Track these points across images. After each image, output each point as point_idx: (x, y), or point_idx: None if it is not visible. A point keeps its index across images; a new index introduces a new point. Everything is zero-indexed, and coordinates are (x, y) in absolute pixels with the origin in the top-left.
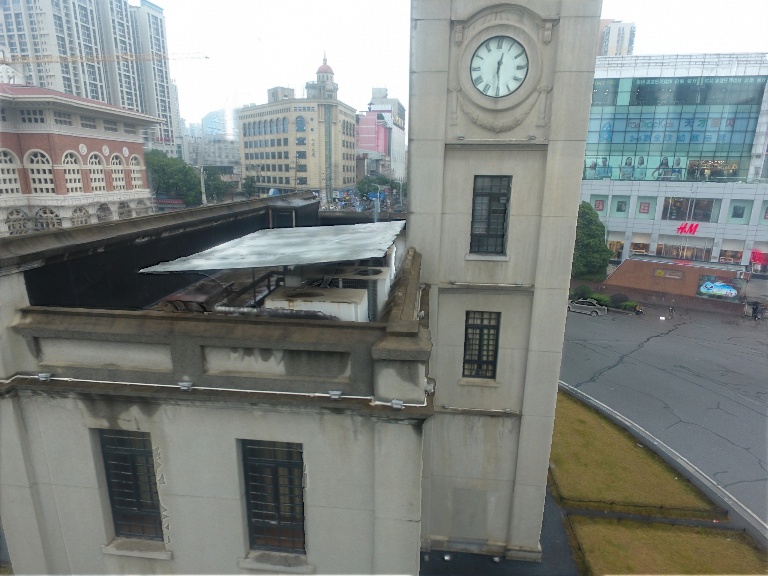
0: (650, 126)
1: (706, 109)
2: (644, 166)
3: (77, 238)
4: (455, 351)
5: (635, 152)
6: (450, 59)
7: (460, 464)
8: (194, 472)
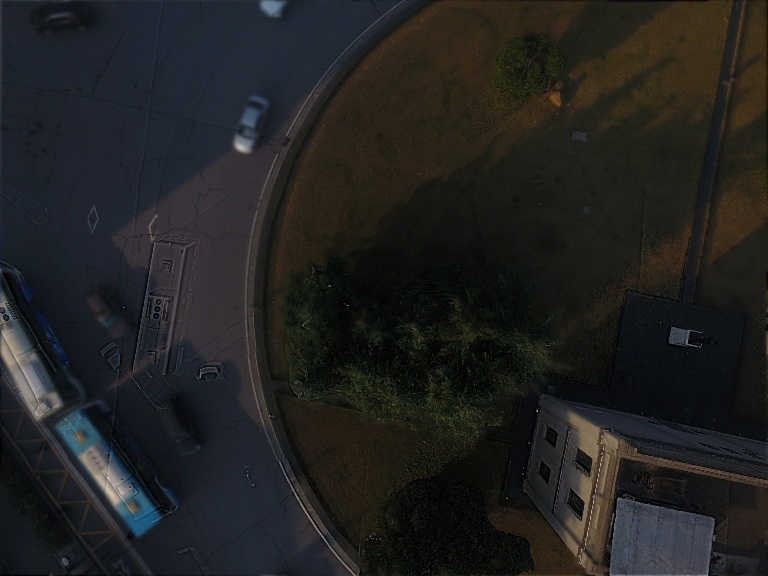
0: None
1: None
2: None
3: (658, 462)
4: None
5: None
6: None
7: None
8: None
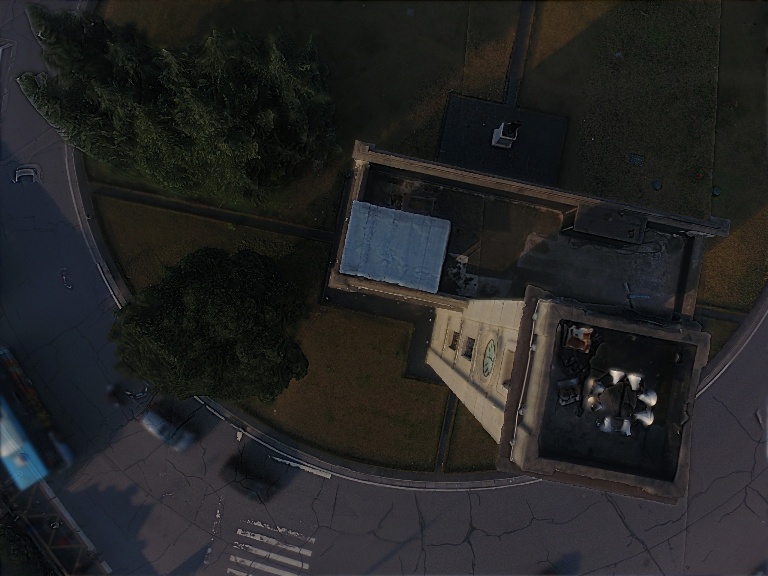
0: None
1: None
2: None
3: (392, 163)
4: None
5: None
6: (495, 326)
7: None
8: None
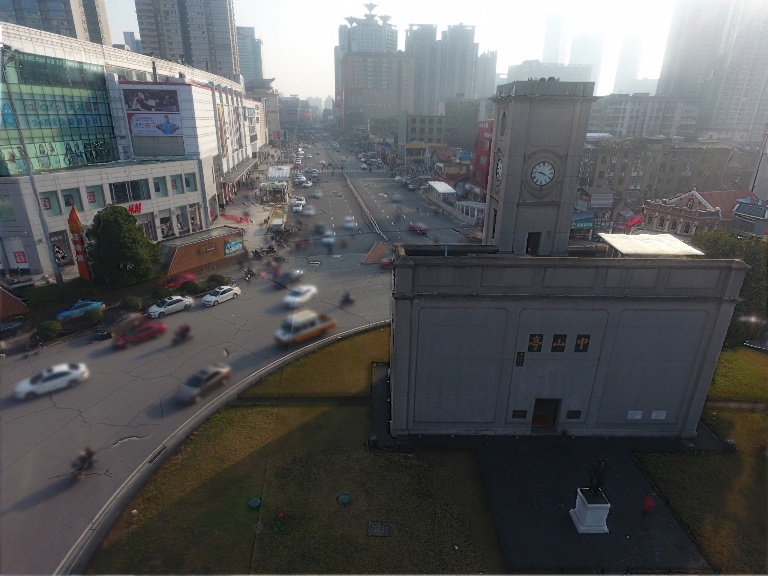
0: (45, 109)
1: (78, 93)
2: (55, 153)
3: None
4: None
5: (43, 138)
6: None
7: None
8: None
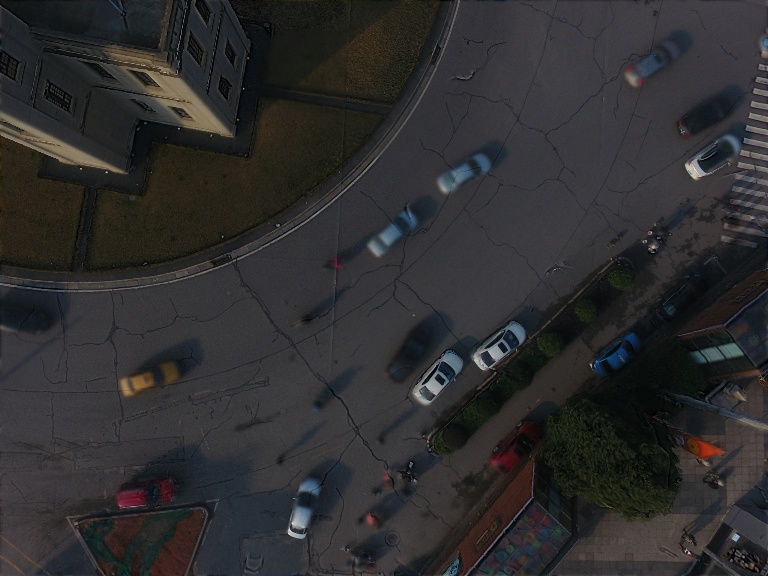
0: None
1: None
2: None
3: None
4: None
5: None
6: None
7: None
8: None
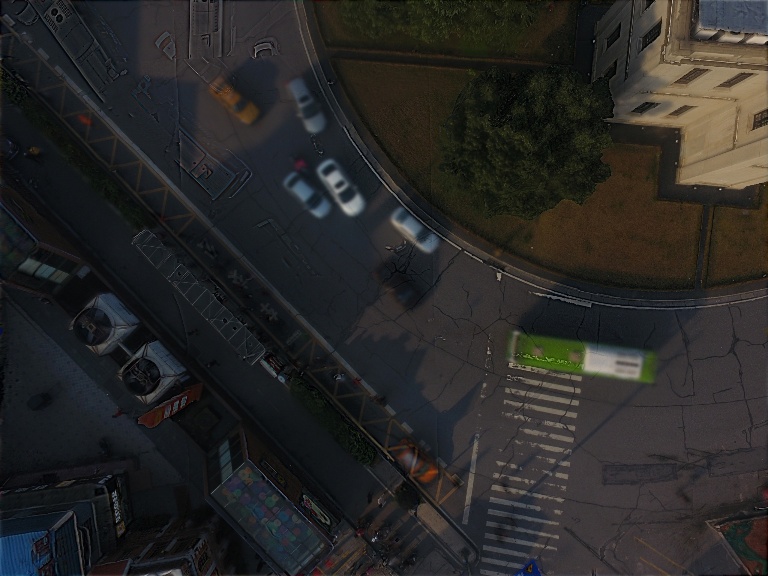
0: None
1: None
2: None
3: None
4: (765, 104)
5: None
6: None
7: (715, 132)
8: (656, 9)
